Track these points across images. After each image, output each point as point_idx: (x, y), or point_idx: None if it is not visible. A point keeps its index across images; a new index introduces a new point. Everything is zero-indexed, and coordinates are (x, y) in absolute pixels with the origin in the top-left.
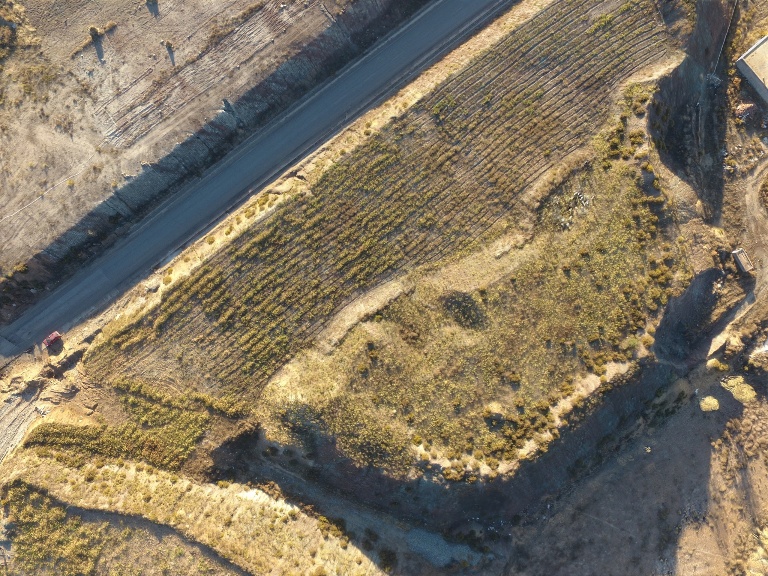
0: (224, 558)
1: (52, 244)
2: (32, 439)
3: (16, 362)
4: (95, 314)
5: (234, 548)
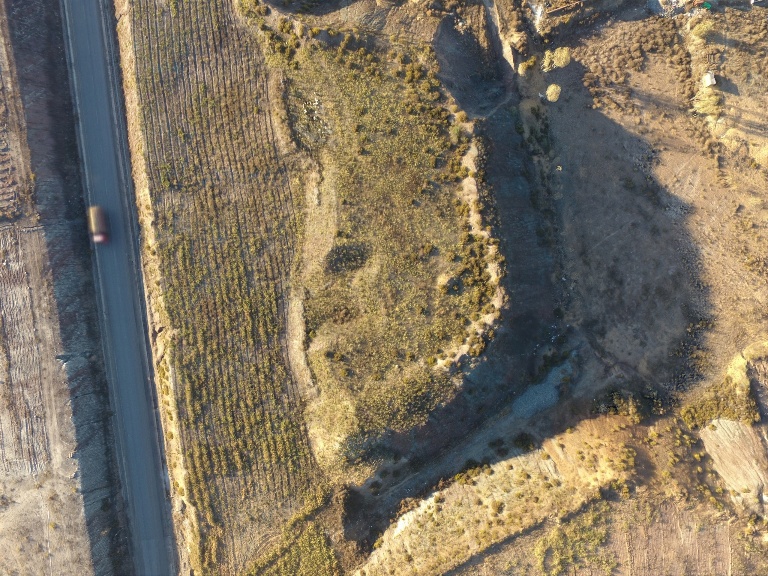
0: None
1: (95, 569)
2: None
3: None
4: (177, 567)
5: (431, 566)
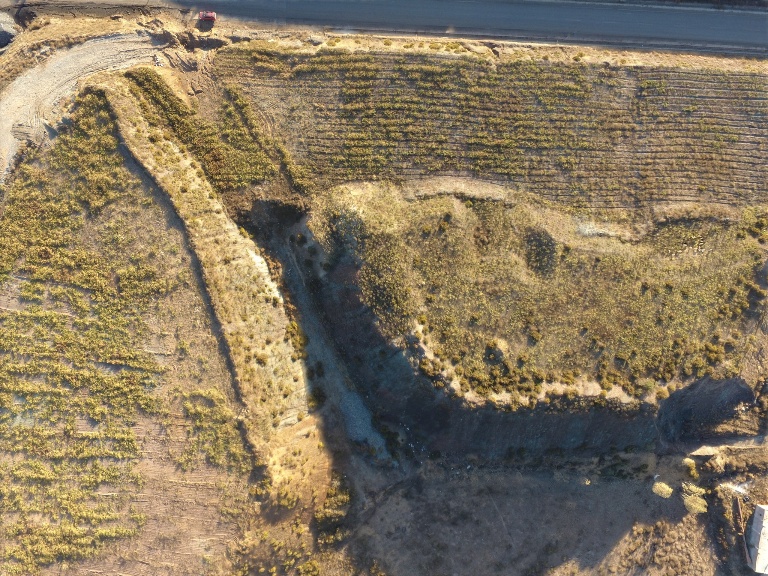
0: (204, 282)
1: None
2: (135, 73)
3: (166, 11)
4: (254, 26)
5: (218, 281)
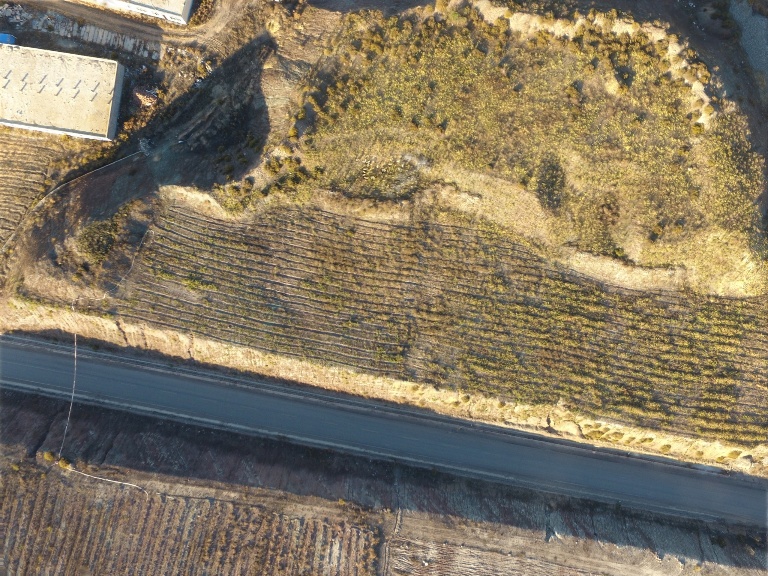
0: None
1: None
2: None
3: None
4: None
5: None
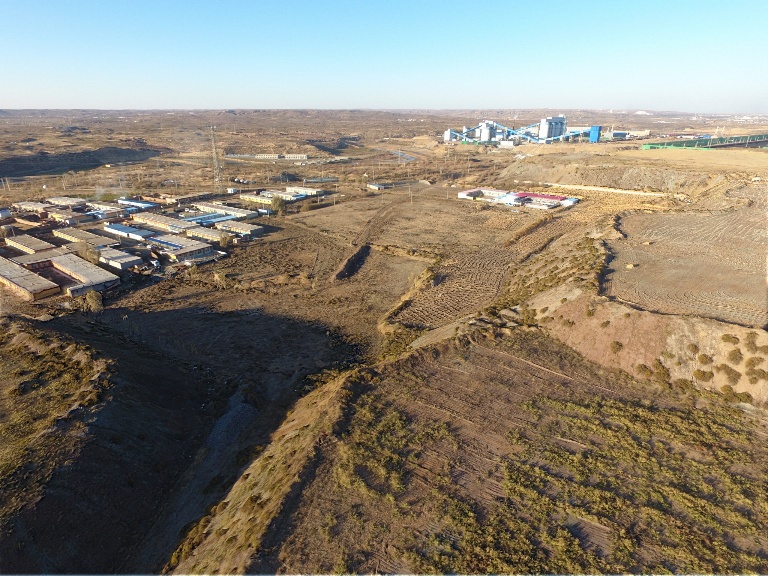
0: None
1: None
2: None
3: None
4: None
5: None
